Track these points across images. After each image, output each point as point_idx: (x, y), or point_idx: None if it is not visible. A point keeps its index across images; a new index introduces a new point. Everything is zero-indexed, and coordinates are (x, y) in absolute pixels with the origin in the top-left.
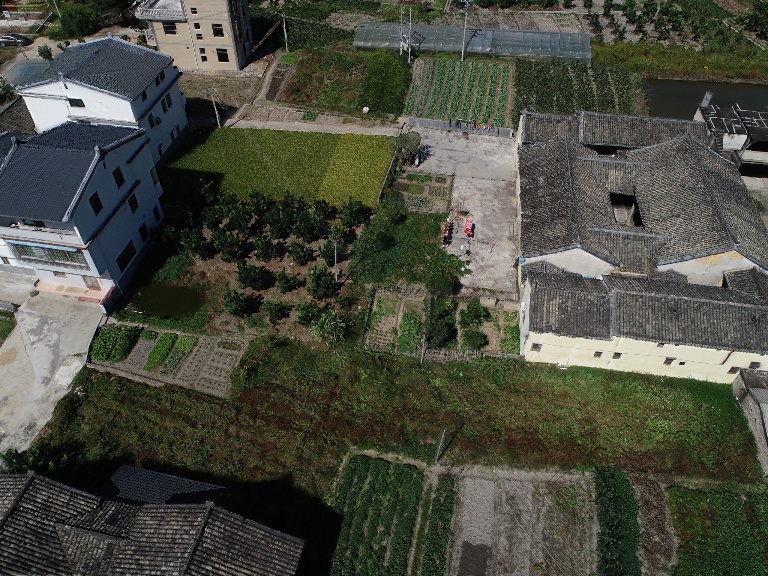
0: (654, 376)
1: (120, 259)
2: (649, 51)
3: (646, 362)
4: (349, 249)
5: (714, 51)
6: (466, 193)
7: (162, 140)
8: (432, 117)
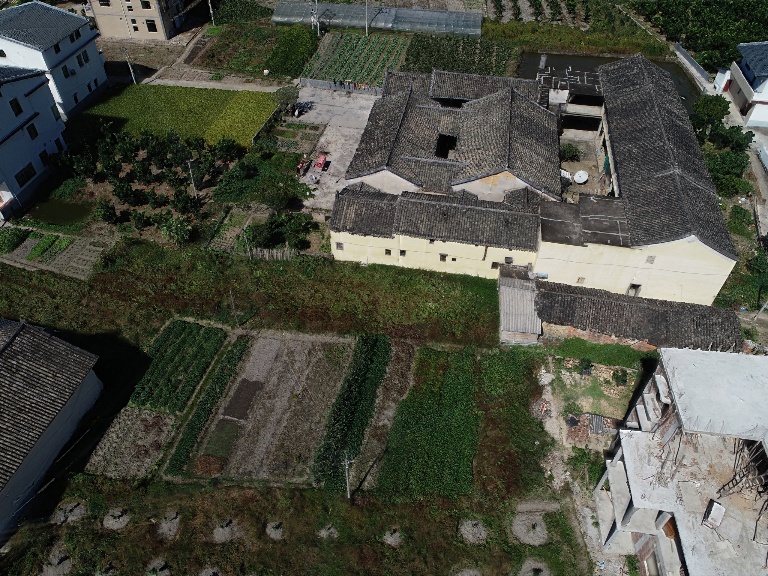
0: (437, 272)
1: (19, 176)
2: (537, 29)
3: (427, 259)
4: (219, 178)
5: (597, 30)
6: (332, 138)
7: (78, 90)
8: (324, 80)
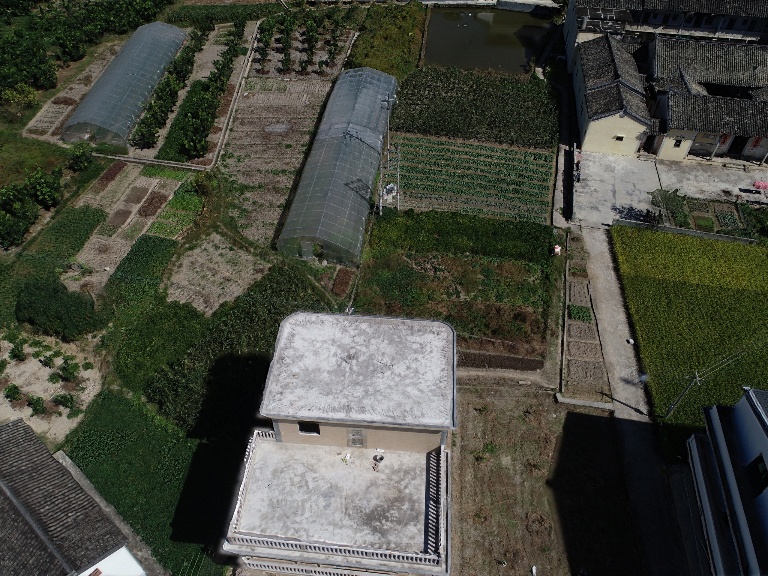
0: None
1: None
2: None
3: None
4: None
5: None
6: (692, 189)
7: None
8: None
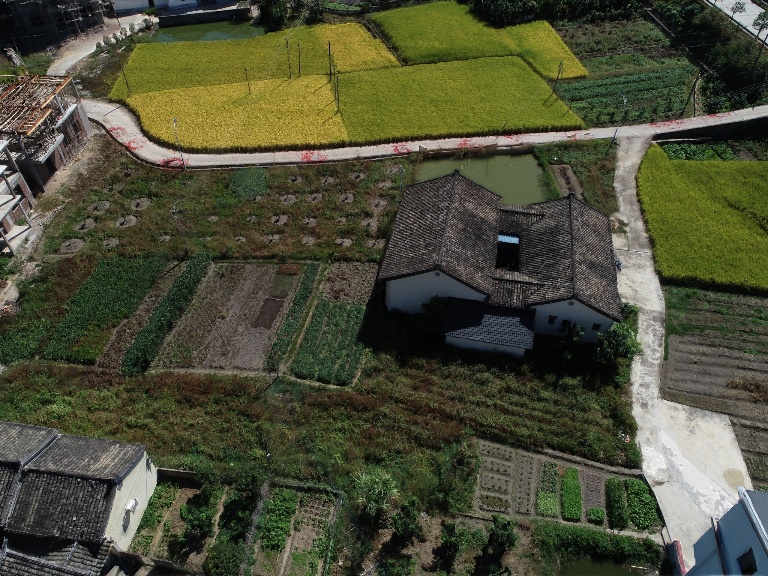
0: None
1: None
2: None
3: None
4: None
5: None
6: None
7: None
8: None
